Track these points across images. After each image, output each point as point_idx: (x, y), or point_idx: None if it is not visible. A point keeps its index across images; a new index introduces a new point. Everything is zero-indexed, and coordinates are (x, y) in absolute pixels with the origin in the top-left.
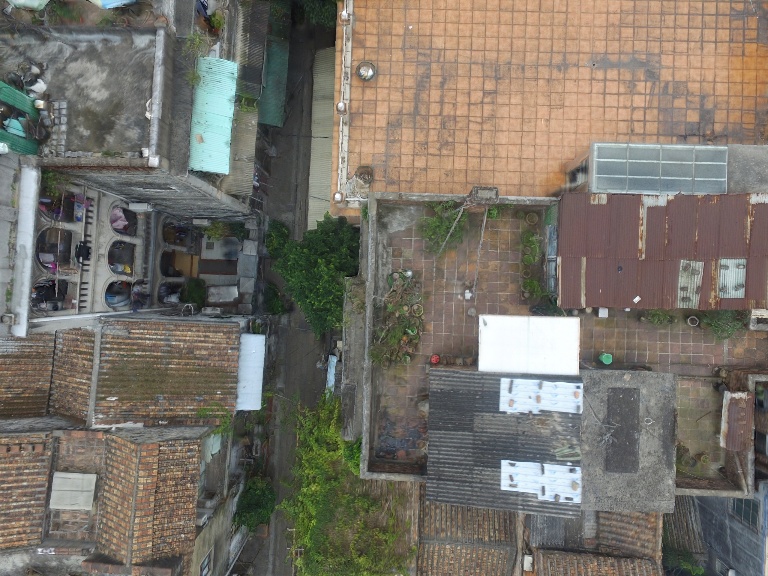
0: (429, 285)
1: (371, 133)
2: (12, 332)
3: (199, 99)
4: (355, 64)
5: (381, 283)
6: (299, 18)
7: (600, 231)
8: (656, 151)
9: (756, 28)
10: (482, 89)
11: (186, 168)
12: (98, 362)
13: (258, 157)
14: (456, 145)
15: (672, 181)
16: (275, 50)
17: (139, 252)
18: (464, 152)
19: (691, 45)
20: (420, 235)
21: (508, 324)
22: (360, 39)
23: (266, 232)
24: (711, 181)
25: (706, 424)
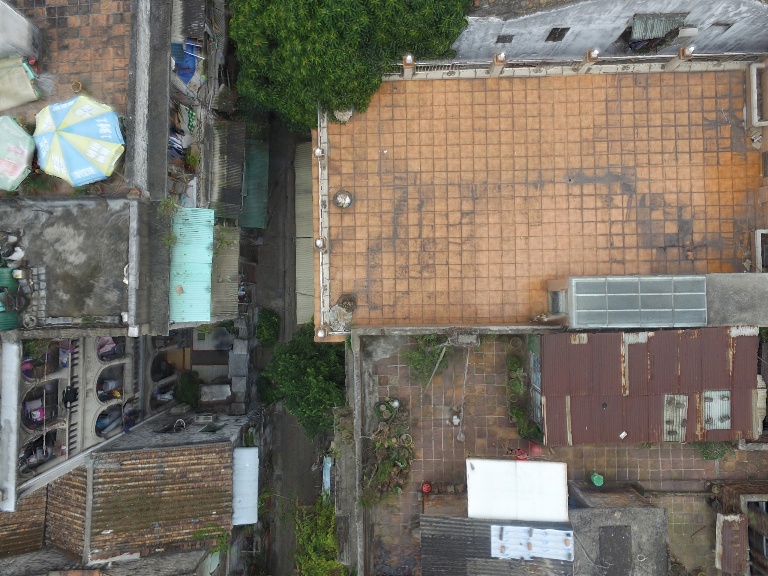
0: (417, 412)
1: (352, 259)
2: (0, 507)
3: (177, 251)
4: (332, 191)
5: (369, 412)
6: (277, 124)
7: (582, 370)
8: (634, 284)
9: (729, 137)
10: (460, 210)
11: (167, 328)
12: (91, 497)
13: (244, 253)
14: (437, 267)
15: (652, 313)
16: (255, 153)
17: (128, 369)
18: (445, 274)
19: (665, 156)
20: (405, 362)
21: (495, 468)
22: (336, 166)
23: (256, 323)
24: (691, 312)
25: (701, 539)
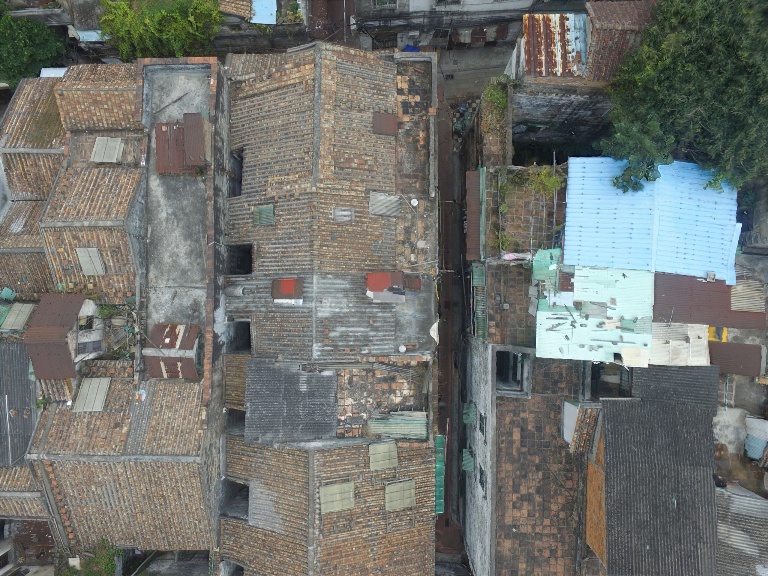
0: None
1: None
2: None
3: None
4: None
5: None
6: None
7: None
8: None
9: None
10: None
11: None
12: (23, 149)
13: None
14: None
15: None
16: None
17: None
18: None
19: None
20: None
21: None
22: None
23: None
24: None
25: None
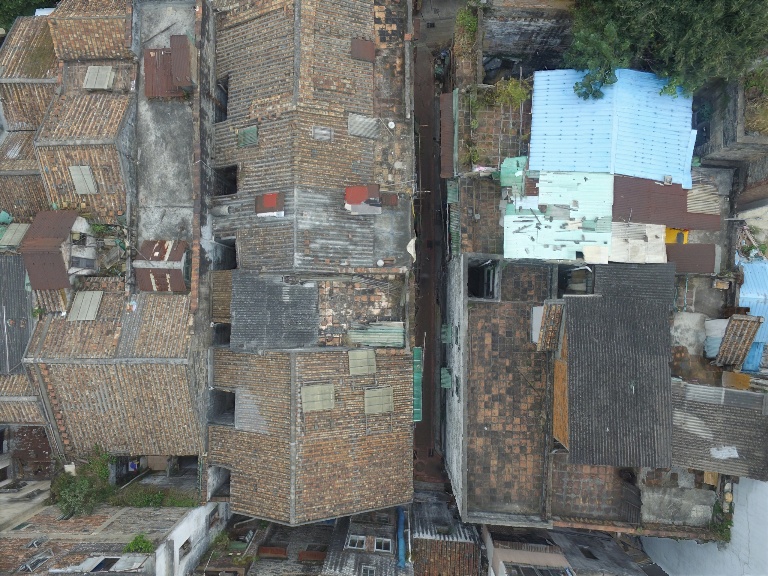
0: None
1: None
2: None
3: None
4: None
5: None
6: None
7: None
8: None
9: None
10: None
11: None
12: (18, 79)
13: None
14: None
15: None
16: None
17: None
18: None
19: None
20: None
21: None
22: None
23: None
24: None
25: None
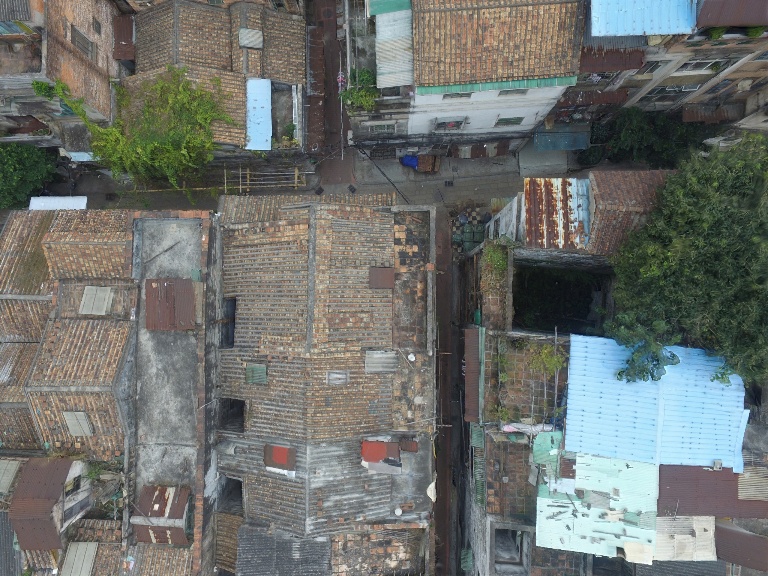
0: None
1: None
2: None
3: None
4: None
5: None
6: None
7: None
8: None
9: None
10: None
11: None
12: (10, 295)
13: None
14: None
15: None
16: None
17: None
18: None
19: None
20: None
21: None
22: None
23: None
24: None
25: None
